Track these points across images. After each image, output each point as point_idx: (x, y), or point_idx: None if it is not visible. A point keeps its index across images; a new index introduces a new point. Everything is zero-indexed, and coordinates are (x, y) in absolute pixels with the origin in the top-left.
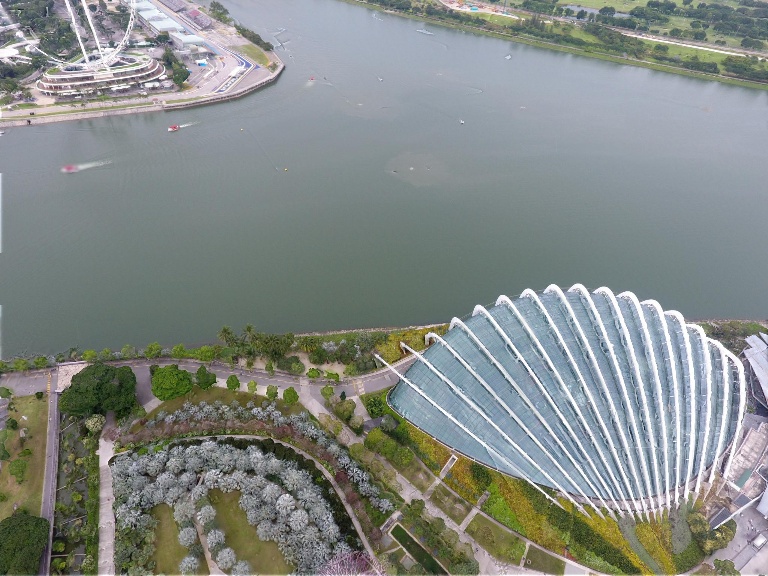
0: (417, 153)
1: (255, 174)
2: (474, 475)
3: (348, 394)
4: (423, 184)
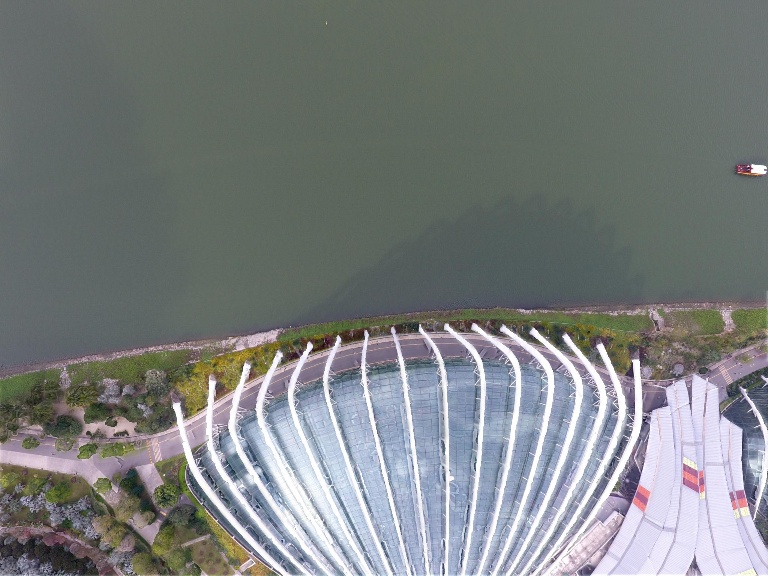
0: None
1: None
2: None
3: (141, 462)
4: None
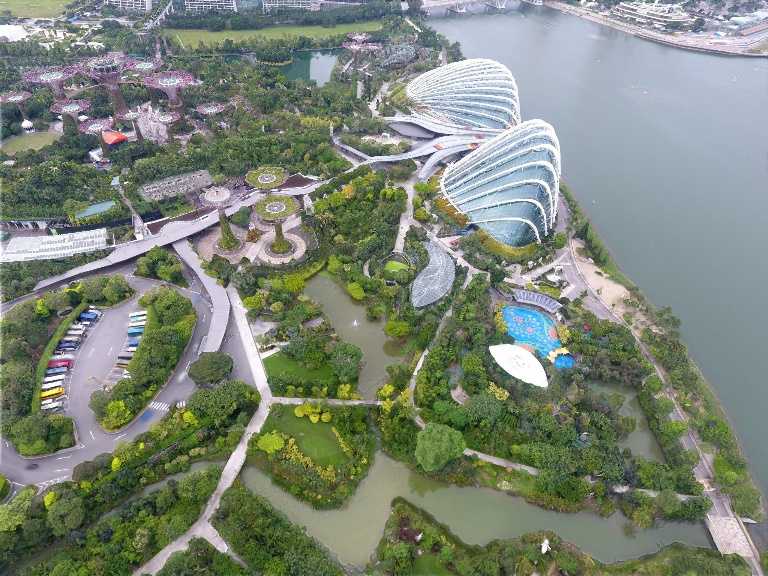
0: (672, 94)
1: (587, 57)
2: None
3: None
4: (628, 94)
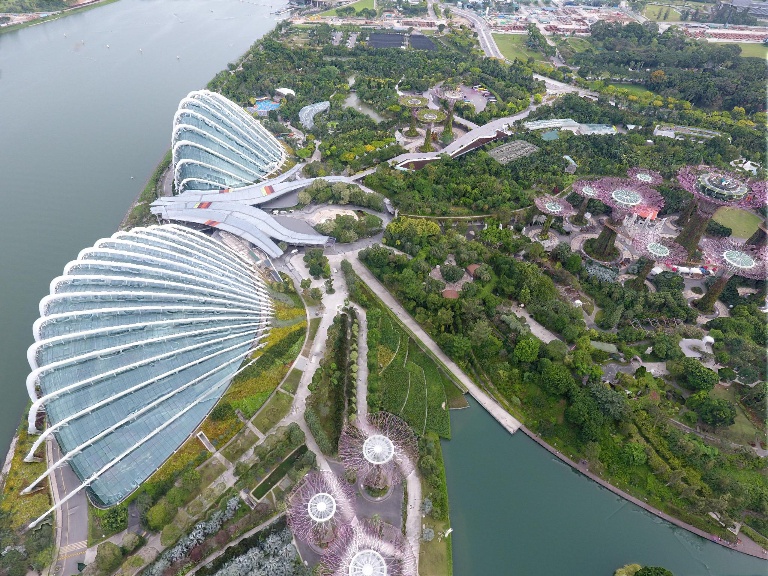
0: None
1: None
2: (220, 418)
3: None
4: None
